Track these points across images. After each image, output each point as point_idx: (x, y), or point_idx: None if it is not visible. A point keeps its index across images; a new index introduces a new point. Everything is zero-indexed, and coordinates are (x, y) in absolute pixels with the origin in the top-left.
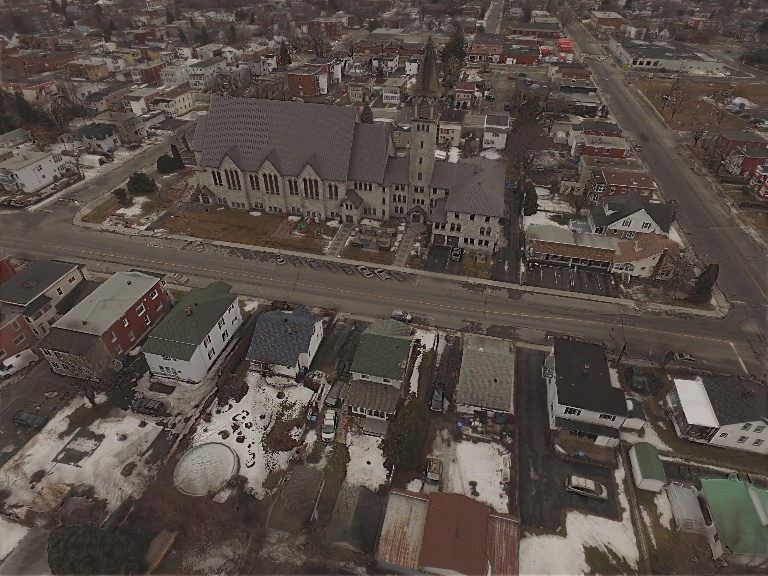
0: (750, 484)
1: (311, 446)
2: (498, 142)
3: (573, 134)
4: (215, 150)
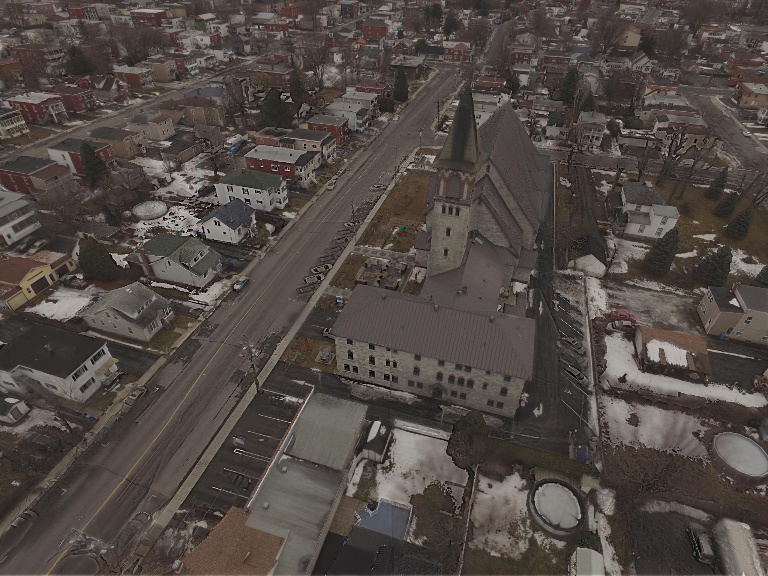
0: None
1: (141, 241)
2: None
3: None
4: None
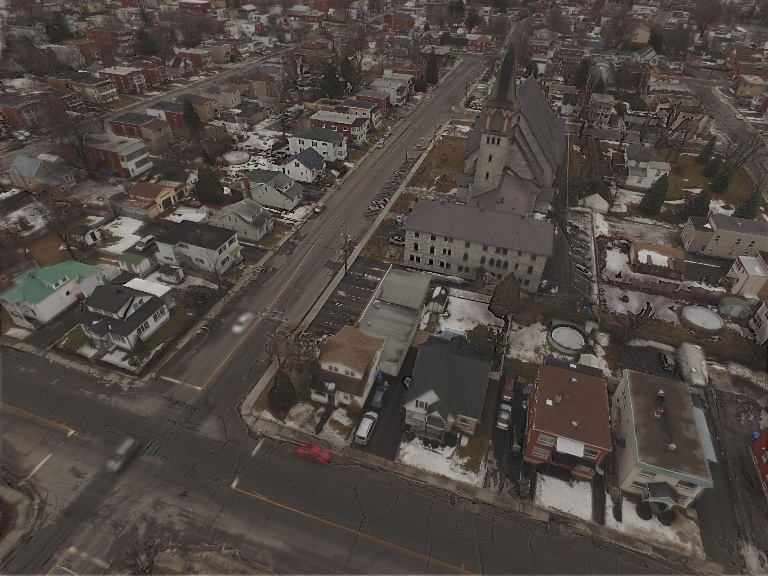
0: (81, 281)
1: None
2: (763, 330)
3: None
4: None
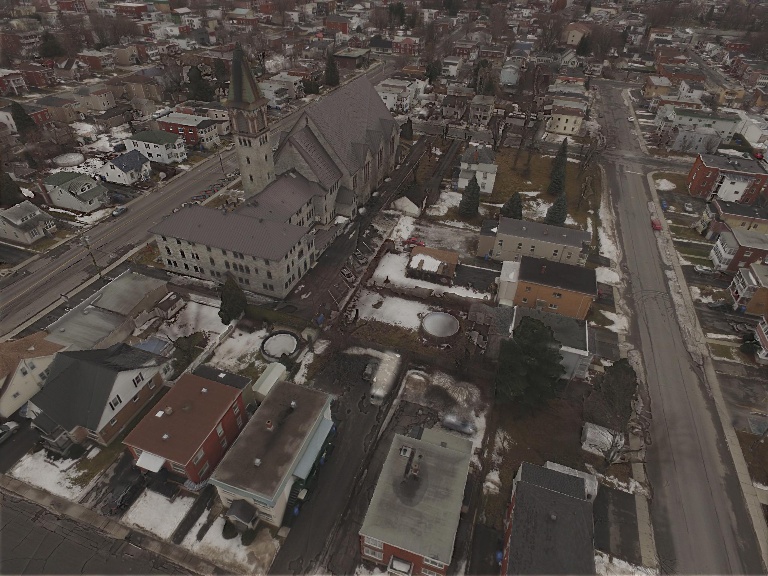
0: None
1: None
2: None
3: (520, 467)
4: None
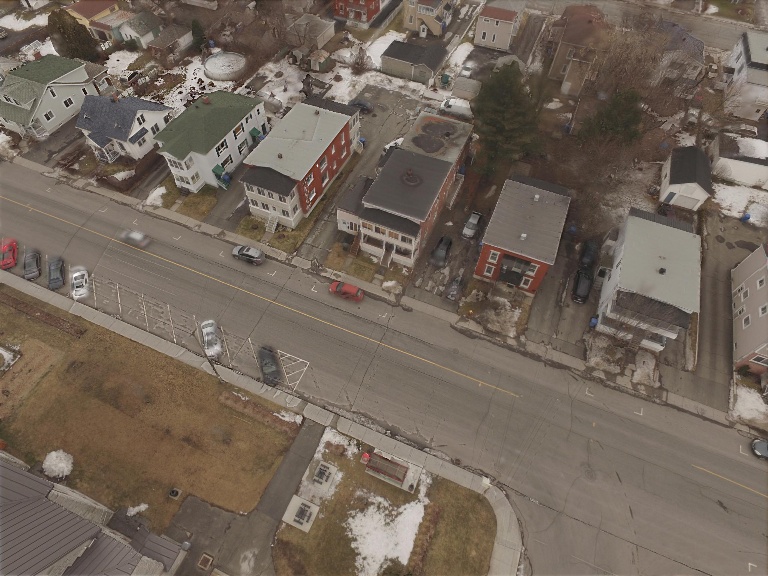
0: None
1: None
2: None
3: None
4: (3, 542)
